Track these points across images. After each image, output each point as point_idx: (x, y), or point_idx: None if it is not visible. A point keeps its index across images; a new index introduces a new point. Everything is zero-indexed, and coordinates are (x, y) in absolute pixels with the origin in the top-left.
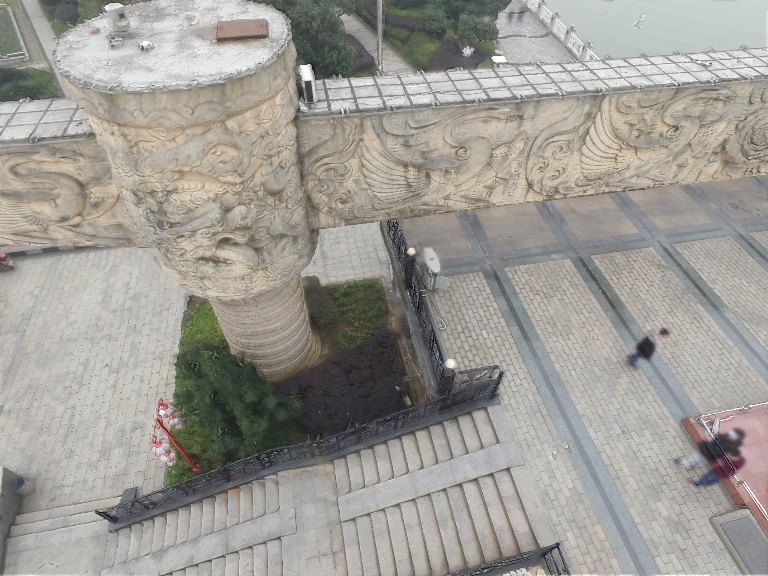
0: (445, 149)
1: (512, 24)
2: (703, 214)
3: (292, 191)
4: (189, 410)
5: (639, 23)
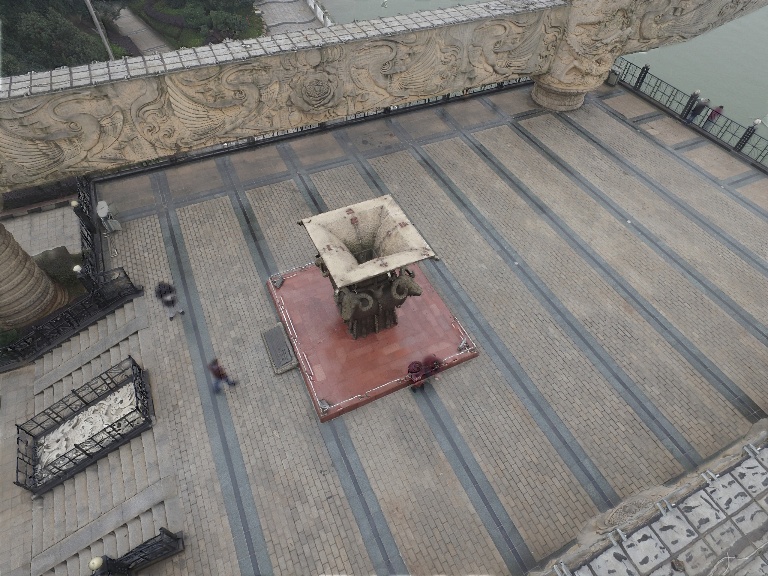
0: (59, 125)
1: (285, 12)
2: (340, 151)
3: None
4: None
5: (384, 3)
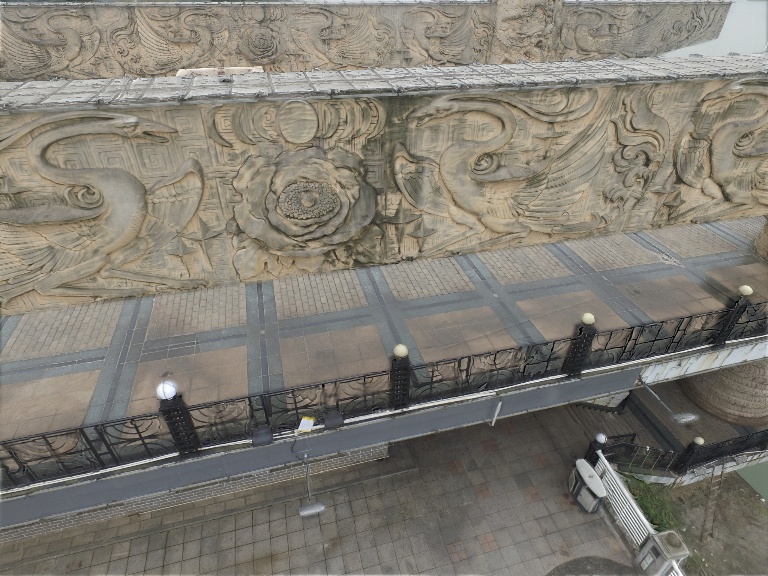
0: (51, 35)
1: None
2: None
3: None
4: None
5: None
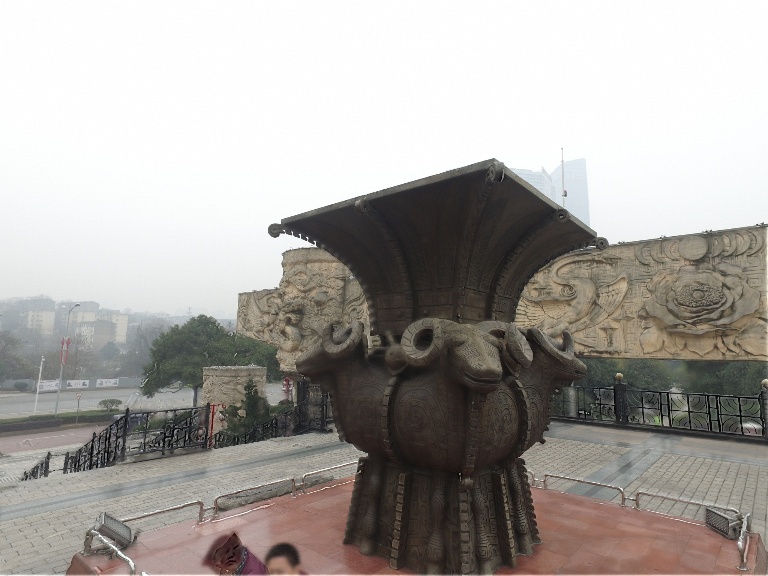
0: None
1: None
2: None
3: (330, 312)
4: (226, 411)
5: None
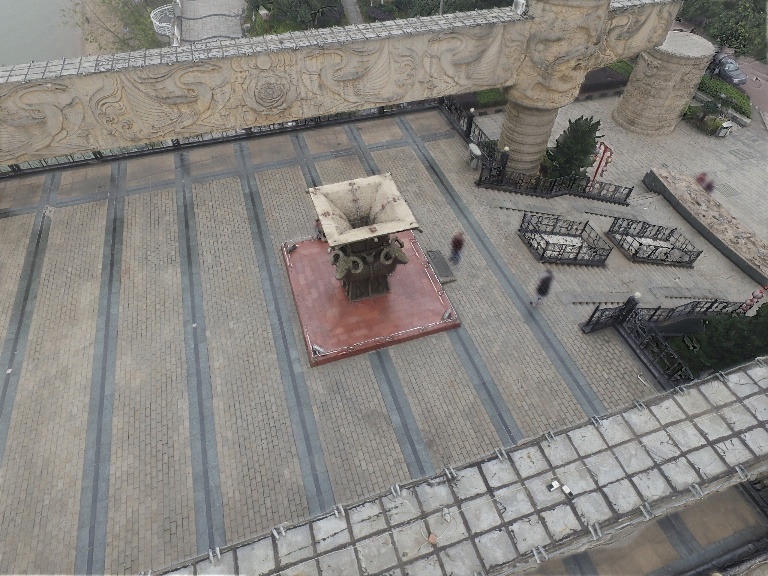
0: None
1: None
2: None
3: None
4: None
5: None
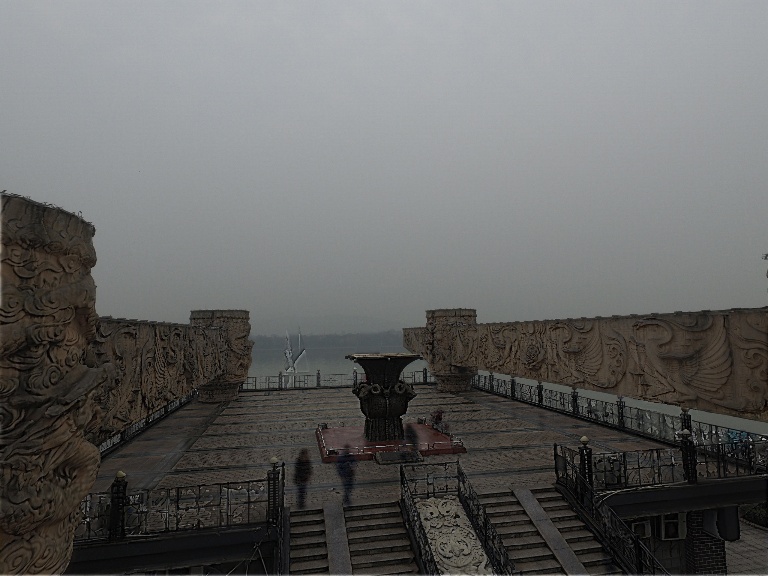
0: (112, 361)
1: None
2: (172, 440)
3: None
4: None
5: None
